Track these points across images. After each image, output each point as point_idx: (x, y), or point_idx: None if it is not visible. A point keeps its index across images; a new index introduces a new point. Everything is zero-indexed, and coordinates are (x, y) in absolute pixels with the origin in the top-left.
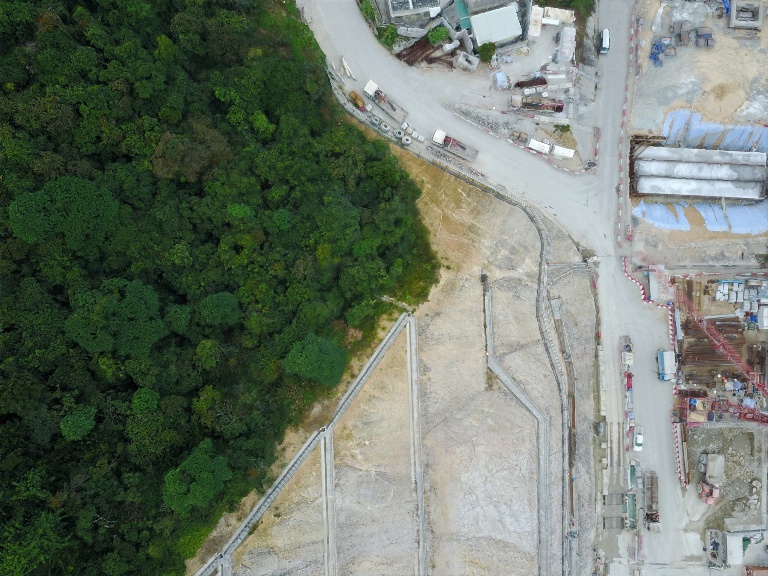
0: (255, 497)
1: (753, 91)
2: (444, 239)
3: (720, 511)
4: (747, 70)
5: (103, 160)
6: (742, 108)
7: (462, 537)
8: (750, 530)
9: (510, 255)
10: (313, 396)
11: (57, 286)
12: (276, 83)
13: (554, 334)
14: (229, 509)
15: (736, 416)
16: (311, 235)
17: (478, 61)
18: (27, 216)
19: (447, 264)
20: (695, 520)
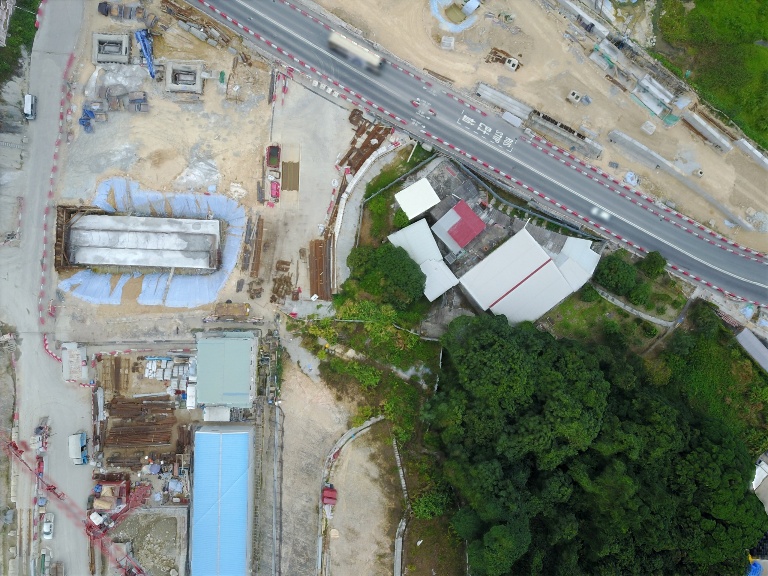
0: None
1: (193, 158)
2: None
3: None
4: (188, 136)
5: None
6: (182, 175)
7: None
8: None
9: None
10: None
11: None
12: None
13: None
14: None
15: (159, 500)
16: None
17: None
18: None
19: None
20: None
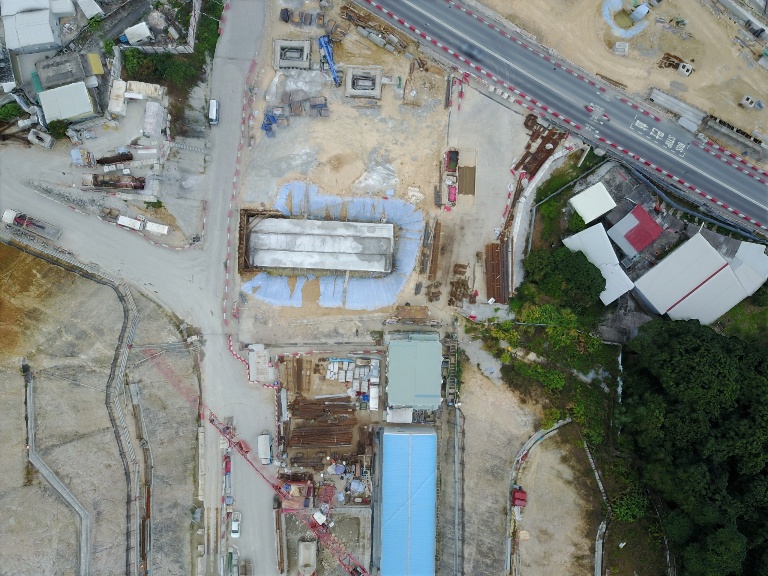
0: None
1: (371, 162)
2: None
3: None
4: (366, 140)
5: None
6: (360, 179)
7: None
8: None
9: (75, 340)
10: None
11: None
12: None
13: (131, 420)
14: None
15: (342, 500)
16: None
17: (50, 138)
18: None
19: None
20: None
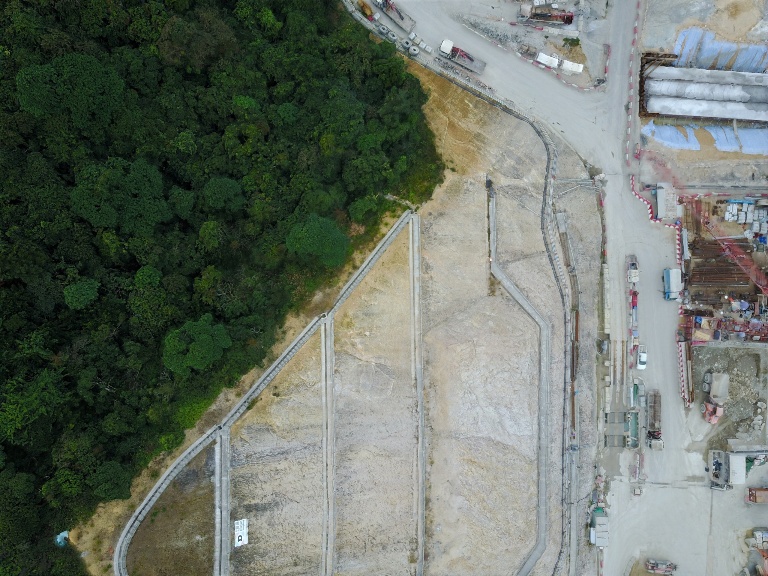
0: (255, 375)
1: None
2: (449, 144)
3: (724, 432)
4: None
5: (110, 46)
6: (756, 27)
7: (461, 435)
8: (754, 451)
9: (516, 165)
10: (314, 284)
11: (63, 164)
12: None
13: (559, 247)
14: (229, 383)
15: (742, 337)
16: (315, 127)
17: None
18: (34, 86)
19: (451, 167)
20: (698, 440)
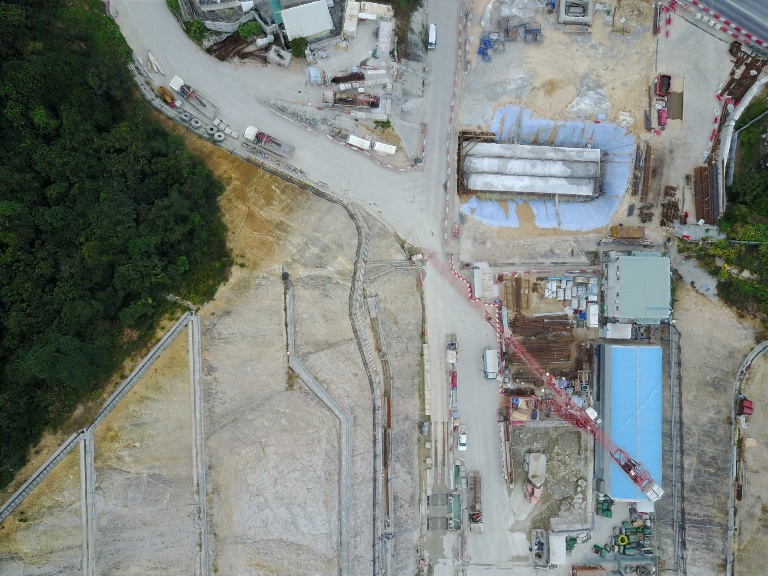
0: None
1: (584, 87)
2: (244, 237)
3: (547, 511)
4: (578, 66)
5: None
6: (573, 104)
7: (248, 540)
8: (574, 529)
9: (320, 253)
10: (76, 397)
11: None
12: (57, 78)
13: (370, 333)
14: None
15: (563, 414)
16: (83, 233)
17: (290, 56)
18: None
19: (241, 262)
20: (521, 520)
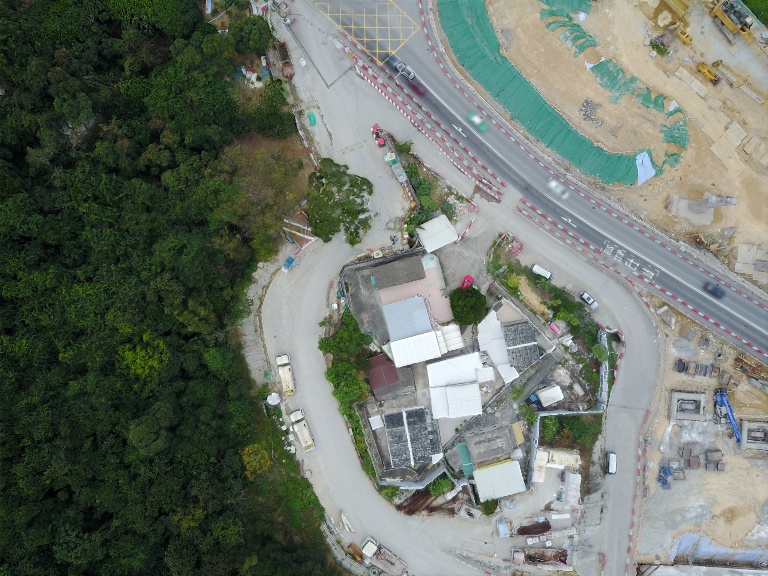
0: None
1: (764, 515)
2: None
3: None
4: (758, 492)
5: None
6: (753, 532)
7: None
8: None
9: None
10: None
11: None
12: None
13: None
14: None
15: None
16: None
17: (480, 514)
18: None
19: None
20: None
